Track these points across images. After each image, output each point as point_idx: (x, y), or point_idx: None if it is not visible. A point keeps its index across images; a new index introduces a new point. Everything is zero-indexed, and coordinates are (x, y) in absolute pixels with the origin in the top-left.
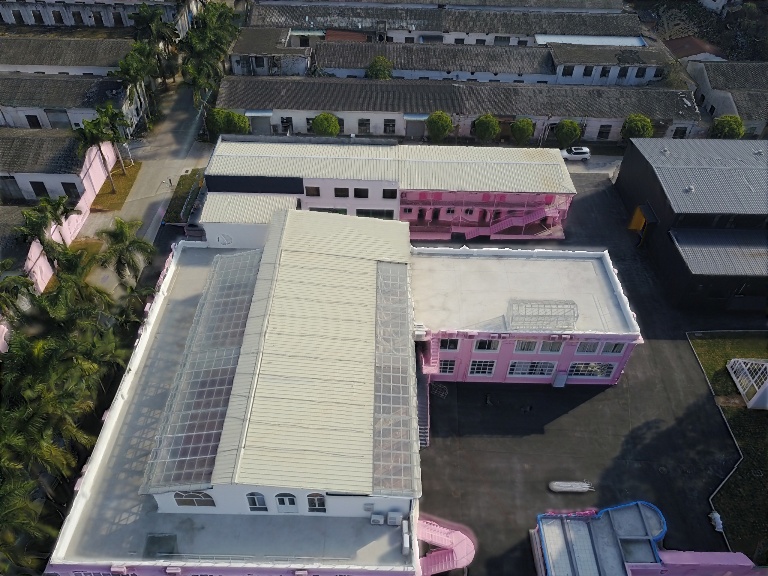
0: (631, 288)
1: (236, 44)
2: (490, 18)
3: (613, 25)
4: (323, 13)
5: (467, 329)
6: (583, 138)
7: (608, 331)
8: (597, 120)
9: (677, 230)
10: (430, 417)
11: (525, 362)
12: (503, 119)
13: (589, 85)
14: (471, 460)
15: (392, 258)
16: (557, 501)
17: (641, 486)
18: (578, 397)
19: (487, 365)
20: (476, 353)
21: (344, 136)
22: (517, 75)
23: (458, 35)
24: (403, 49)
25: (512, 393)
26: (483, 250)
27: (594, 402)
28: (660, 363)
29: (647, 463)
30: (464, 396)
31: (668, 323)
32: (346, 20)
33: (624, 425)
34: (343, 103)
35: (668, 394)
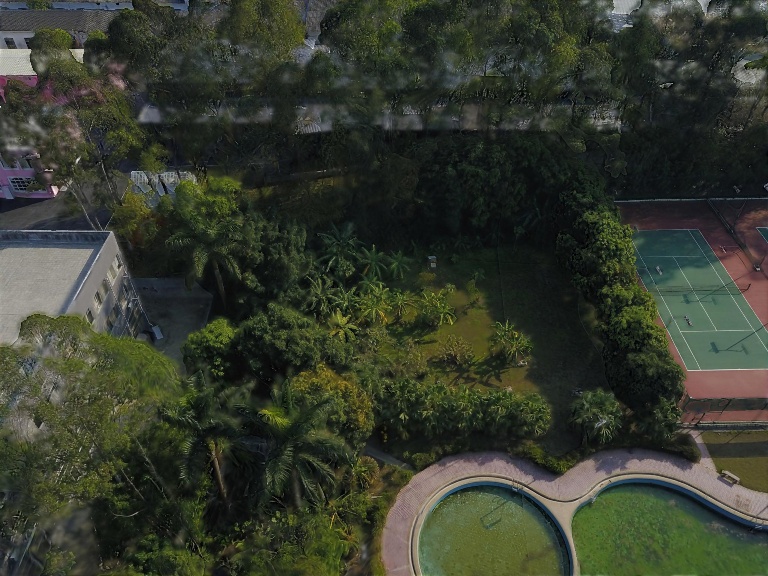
0: None
1: None
2: None
3: None
4: None
5: None
6: None
7: None
8: None
9: None
10: None
11: None
12: None
13: None
14: None
15: None
16: None
17: None
18: (20, 204)
19: None
20: None
21: None
22: None
23: None
24: None
25: None
26: None
27: (29, 207)
28: None
29: None
30: None
31: (130, 163)
32: None
33: (36, 219)
34: None
35: None
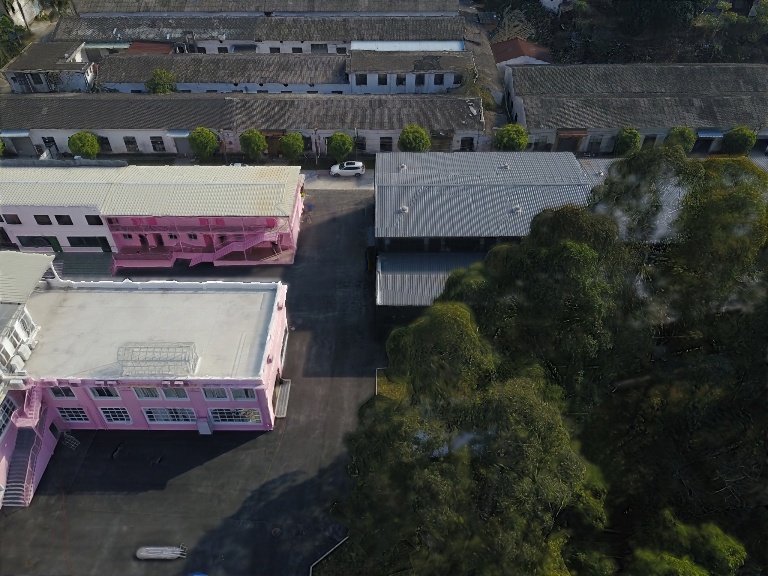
0: (338, 319)
1: (16, 60)
2: (307, 25)
3: (436, 29)
4: (133, 24)
5: (70, 376)
6: (366, 151)
7: (234, 375)
8: (374, 132)
9: (386, 255)
10: (47, 471)
11: (159, 409)
12: (271, 134)
13: (381, 94)
14: (67, 522)
15: (5, 298)
16: (138, 570)
17: (242, 551)
18: (223, 446)
19: (121, 412)
20: (98, 400)
21: (114, 155)
22: (308, 85)
23: (272, 44)
24: (192, 61)
25: (151, 442)
26: (147, 283)
27: (238, 451)
28: (331, 405)
29: (262, 523)
30: (98, 446)
31: (362, 358)
32: (155, 31)
33: (258, 478)
34: (105, 121)
35: (324, 441)
